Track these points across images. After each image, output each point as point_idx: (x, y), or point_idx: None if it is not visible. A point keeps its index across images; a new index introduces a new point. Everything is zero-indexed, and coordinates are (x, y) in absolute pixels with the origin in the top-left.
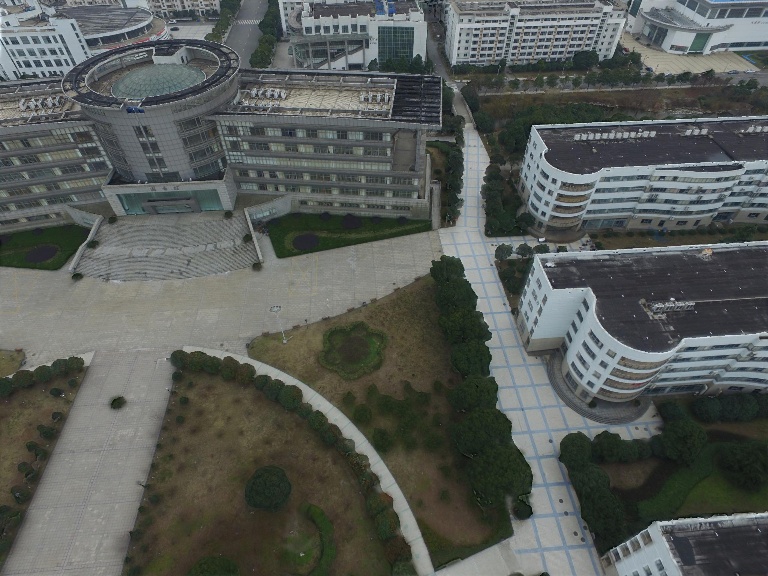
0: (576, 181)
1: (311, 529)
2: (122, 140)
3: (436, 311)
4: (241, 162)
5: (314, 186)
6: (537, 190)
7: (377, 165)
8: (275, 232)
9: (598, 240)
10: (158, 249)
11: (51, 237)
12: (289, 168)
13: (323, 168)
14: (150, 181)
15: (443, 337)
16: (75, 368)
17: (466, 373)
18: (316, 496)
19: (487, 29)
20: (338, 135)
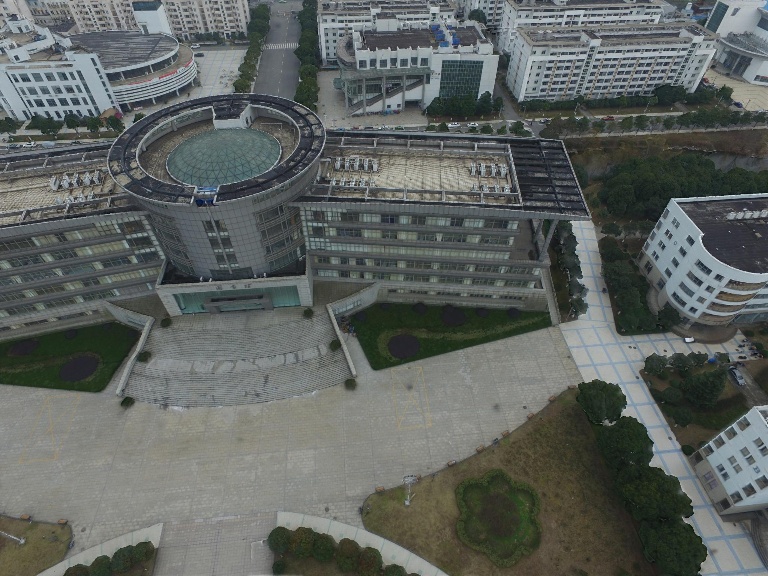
0: (751, 280)
1: None
2: (186, 235)
3: (588, 451)
4: (323, 248)
5: (409, 274)
6: (687, 282)
7: (493, 254)
8: (364, 332)
9: (755, 339)
10: (226, 362)
11: (88, 342)
12: (383, 256)
13: (425, 256)
14: (214, 277)
15: (608, 493)
16: (143, 560)
17: (676, 574)
18: None
19: (562, 61)
20: (452, 222)
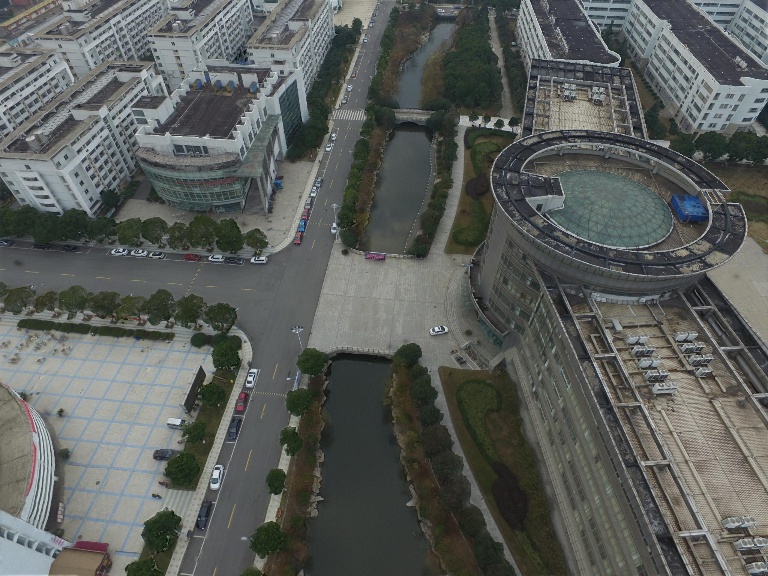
0: None
1: None
2: None
3: None
4: None
5: None
6: None
7: None
8: None
9: None
10: None
11: None
12: None
13: None
14: None
15: (723, 169)
16: None
17: None
18: None
19: None
20: None
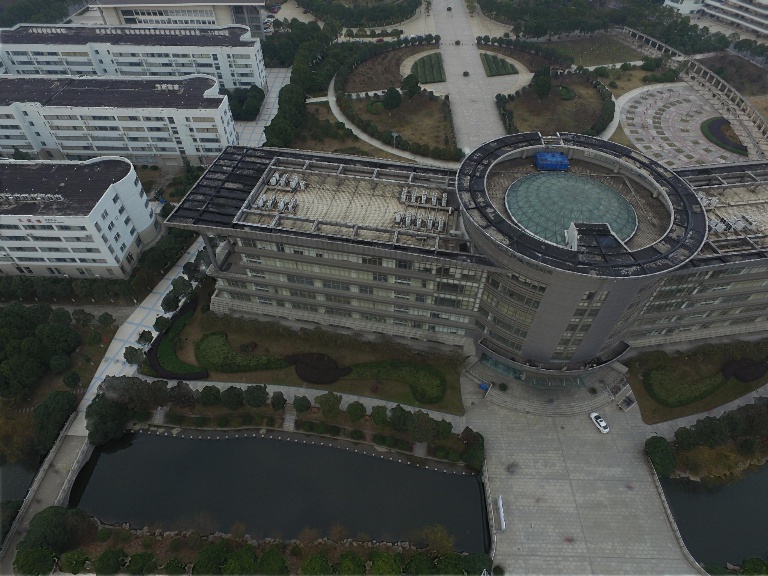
0: None
1: (376, 109)
2: None
3: None
4: None
5: None
6: None
7: None
8: None
9: None
10: None
11: None
12: None
13: None
14: None
15: None
16: None
17: None
18: (374, 117)
19: None
20: None
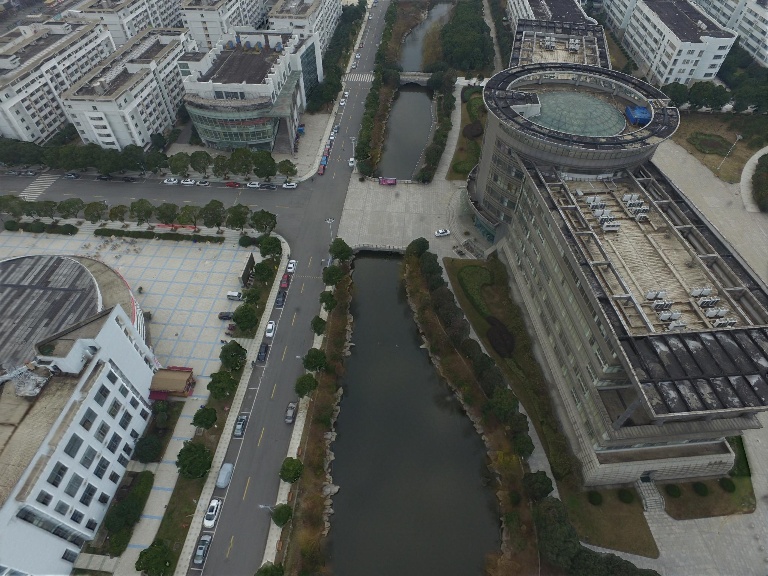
0: None
1: None
2: None
3: None
4: None
5: None
6: None
7: None
8: None
9: None
10: None
11: None
12: None
13: None
14: None
15: (685, 116)
16: None
17: None
18: None
19: None
20: None
